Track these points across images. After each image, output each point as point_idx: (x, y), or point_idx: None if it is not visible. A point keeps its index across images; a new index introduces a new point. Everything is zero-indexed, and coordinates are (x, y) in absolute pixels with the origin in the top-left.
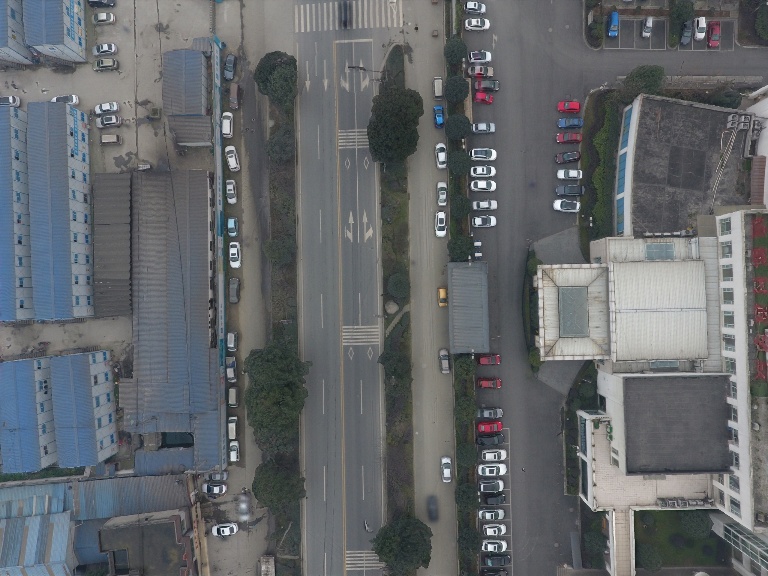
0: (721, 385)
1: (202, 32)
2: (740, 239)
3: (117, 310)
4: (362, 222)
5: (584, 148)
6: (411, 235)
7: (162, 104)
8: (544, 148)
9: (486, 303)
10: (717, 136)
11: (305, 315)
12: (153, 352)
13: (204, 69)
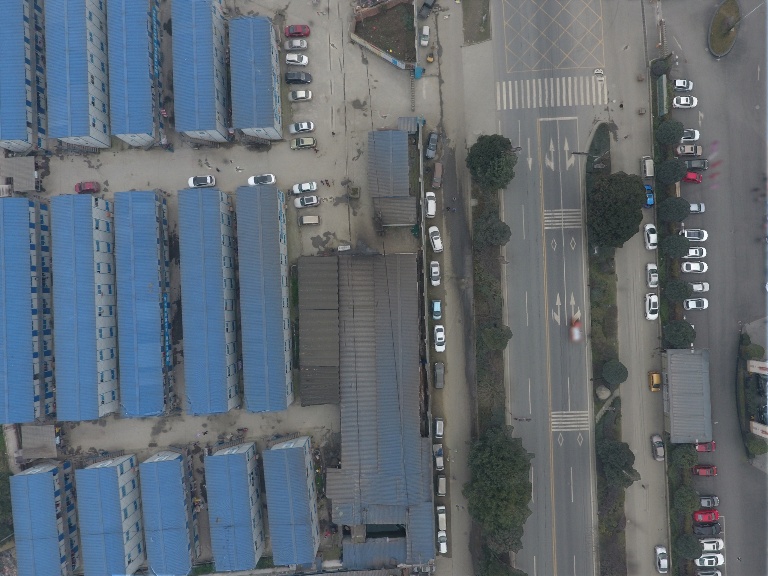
0: None
1: (401, 109)
2: None
3: (325, 398)
4: (570, 304)
5: None
6: (619, 317)
7: (361, 183)
8: (754, 228)
9: (707, 391)
10: None
11: (512, 400)
12: (361, 441)
13: None
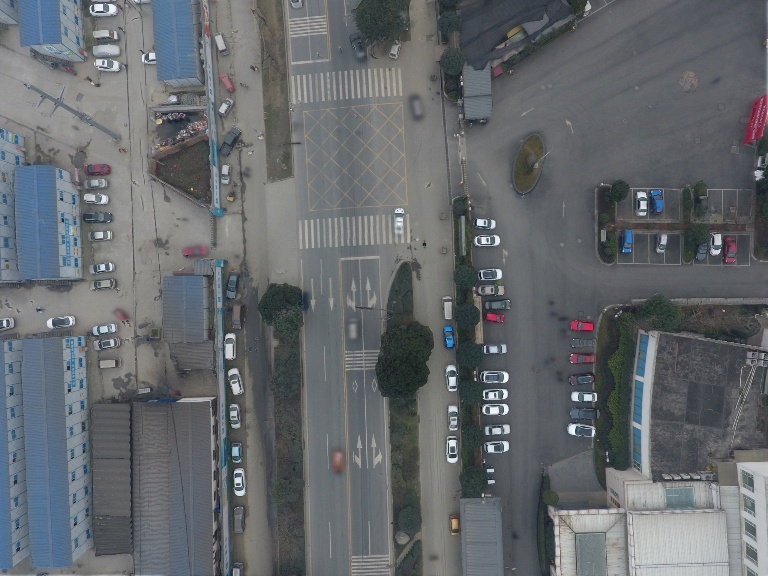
0: None
1: (203, 248)
2: (764, 506)
3: (118, 549)
4: (371, 447)
5: (598, 368)
6: (421, 459)
7: None
8: (557, 367)
9: (500, 540)
10: (736, 371)
11: (313, 544)
12: None
13: (205, 290)
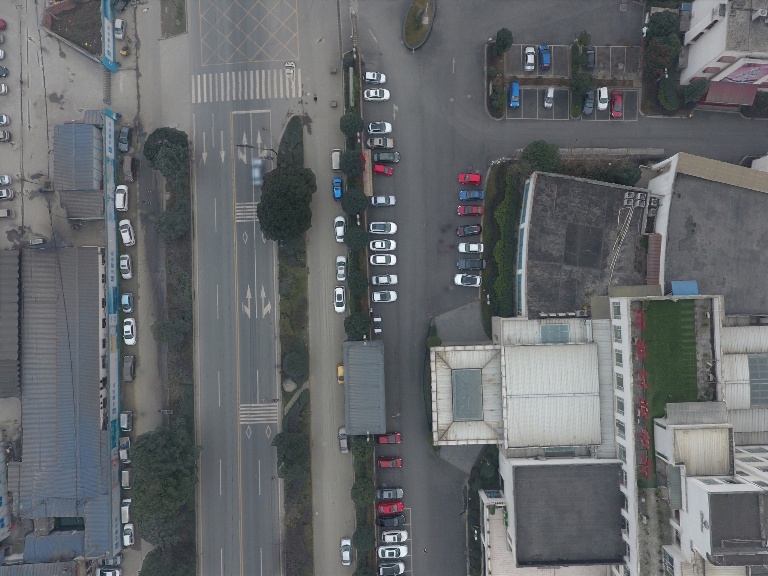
0: (614, 472)
1: (97, 102)
2: (627, 327)
3: (5, 392)
4: (260, 297)
5: (486, 220)
6: (310, 310)
7: None
8: (446, 220)
9: (382, 383)
10: (614, 213)
11: (202, 393)
12: (43, 434)
13: (97, 141)
